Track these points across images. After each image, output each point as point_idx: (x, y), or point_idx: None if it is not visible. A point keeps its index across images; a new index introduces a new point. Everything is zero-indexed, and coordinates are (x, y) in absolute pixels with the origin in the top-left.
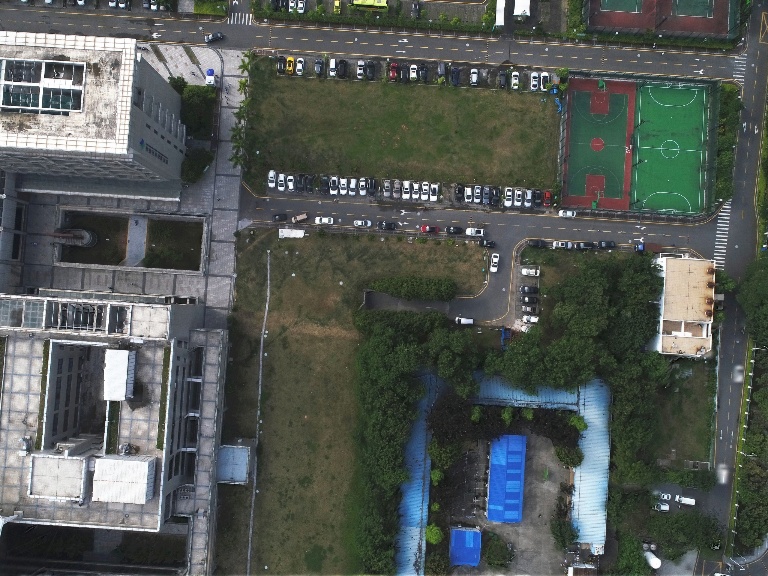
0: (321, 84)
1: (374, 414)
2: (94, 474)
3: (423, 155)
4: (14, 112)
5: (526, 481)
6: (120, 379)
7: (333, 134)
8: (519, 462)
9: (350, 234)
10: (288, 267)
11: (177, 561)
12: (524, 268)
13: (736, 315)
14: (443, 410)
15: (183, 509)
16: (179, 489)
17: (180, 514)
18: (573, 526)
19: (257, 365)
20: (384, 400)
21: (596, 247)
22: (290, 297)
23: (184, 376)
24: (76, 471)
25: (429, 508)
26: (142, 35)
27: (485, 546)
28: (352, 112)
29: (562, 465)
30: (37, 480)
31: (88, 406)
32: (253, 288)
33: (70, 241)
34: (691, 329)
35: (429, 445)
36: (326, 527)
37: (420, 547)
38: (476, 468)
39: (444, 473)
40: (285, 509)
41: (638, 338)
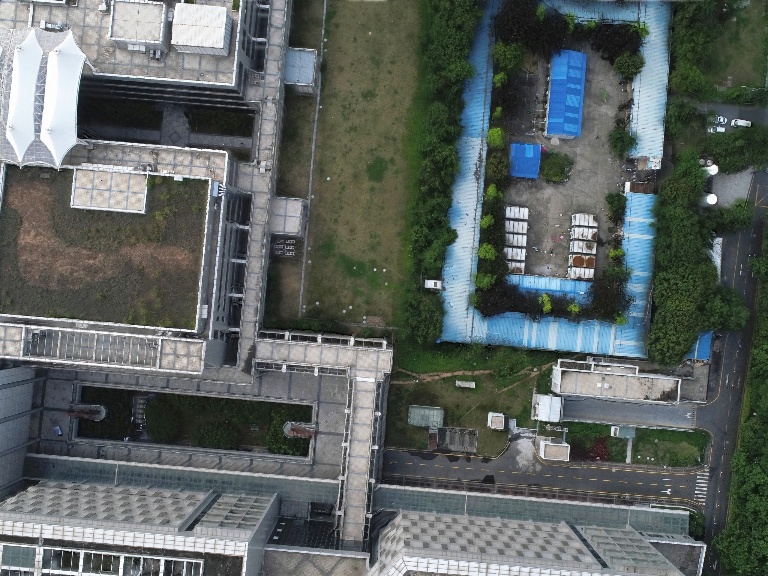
0: None
1: (441, 6)
2: None
3: None
4: None
5: (585, 99)
6: None
7: None
8: (579, 78)
9: None
10: None
11: None
12: None
13: None
14: (509, 6)
15: (252, 96)
16: (250, 71)
17: (249, 101)
18: (632, 137)
19: None
20: None
21: None
22: None
23: None
24: (156, 16)
25: (490, 118)
26: None
27: (544, 161)
28: None
29: (620, 89)
30: (117, 24)
31: None
32: None
33: None
34: None
35: (491, 58)
36: (388, 140)
37: (481, 157)
38: (536, 91)
39: (507, 75)
40: (348, 122)
41: None
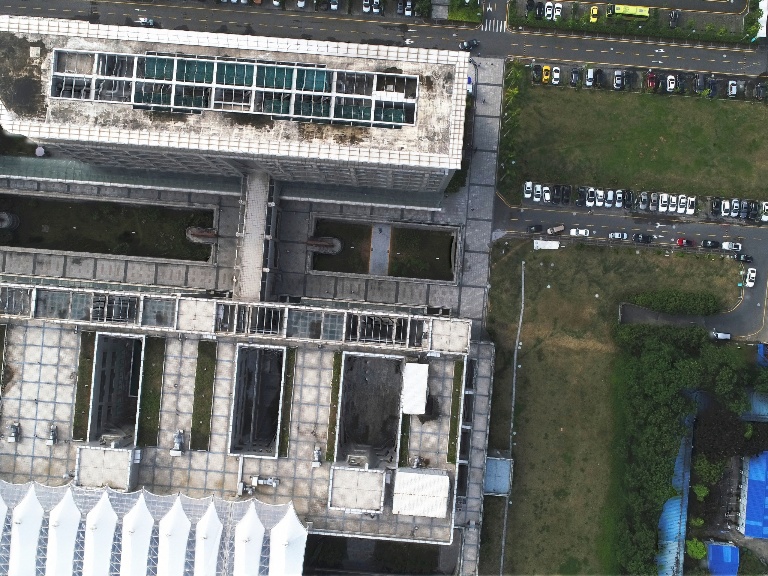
0: (577, 94)
1: (648, 429)
2: (395, 487)
3: (681, 168)
4: (346, 125)
5: None
6: (420, 393)
7: (590, 145)
8: None
9: (605, 246)
10: (543, 279)
11: (433, 571)
12: None
13: None
14: (716, 426)
15: None
16: None
17: None
18: None
19: (511, 377)
20: (660, 416)
21: None
22: (545, 309)
23: None
24: (376, 484)
25: (688, 523)
26: (395, 41)
27: (740, 561)
28: (610, 123)
29: None
30: (337, 492)
31: (350, 416)
32: (507, 299)
33: (322, 249)
34: None
35: (688, 460)
36: (581, 539)
37: (678, 561)
38: (729, 483)
39: (710, 489)
40: (540, 521)
41: None
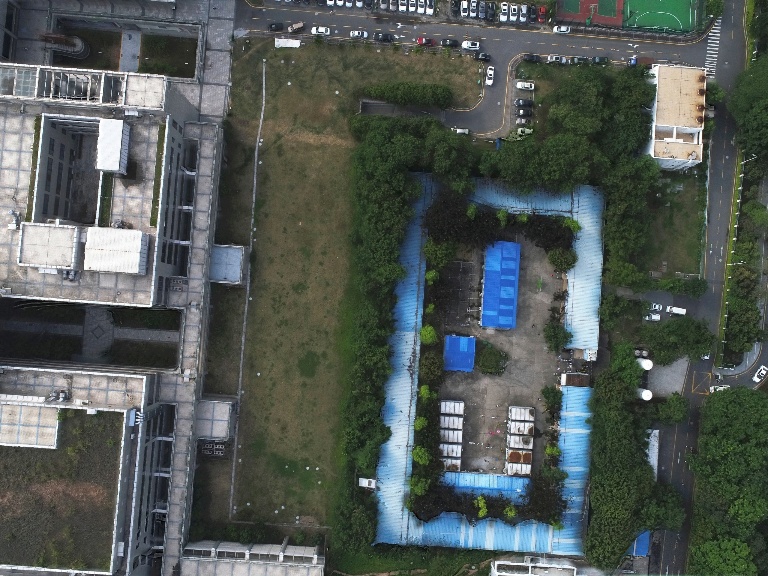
0: None
1: (370, 208)
2: (86, 243)
3: None
4: None
5: (520, 289)
6: (114, 148)
7: None
8: (513, 269)
9: (346, 45)
10: (284, 76)
11: (168, 366)
12: (519, 82)
13: (726, 123)
14: (439, 206)
15: (175, 302)
16: (172, 278)
17: (172, 306)
18: (566, 330)
19: (251, 173)
20: (380, 192)
21: (590, 61)
22: (286, 105)
23: (178, 162)
24: (67, 240)
25: (424, 312)
26: None
27: (479, 353)
28: None
29: (555, 276)
30: (27, 249)
31: (79, 204)
32: (248, 97)
33: (62, 47)
34: (683, 136)
35: None
36: (320, 333)
37: (414, 351)
38: (470, 278)
39: (439, 273)
40: (278, 315)
41: (631, 141)
